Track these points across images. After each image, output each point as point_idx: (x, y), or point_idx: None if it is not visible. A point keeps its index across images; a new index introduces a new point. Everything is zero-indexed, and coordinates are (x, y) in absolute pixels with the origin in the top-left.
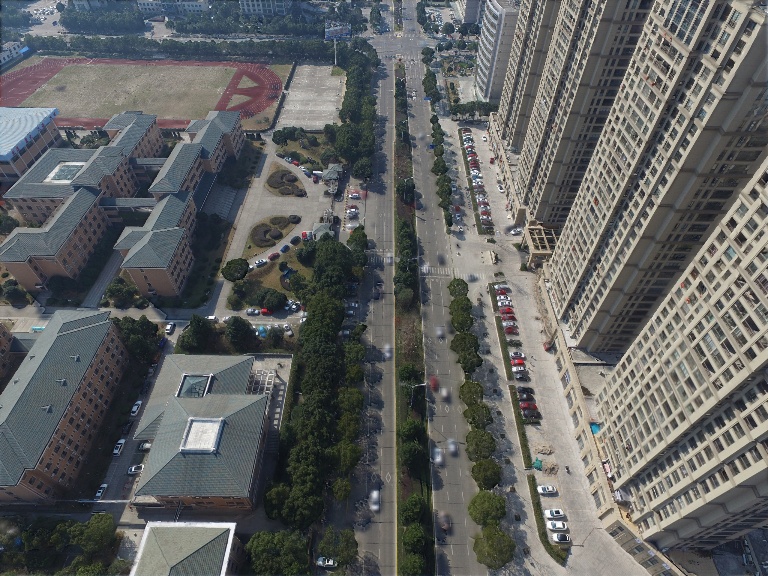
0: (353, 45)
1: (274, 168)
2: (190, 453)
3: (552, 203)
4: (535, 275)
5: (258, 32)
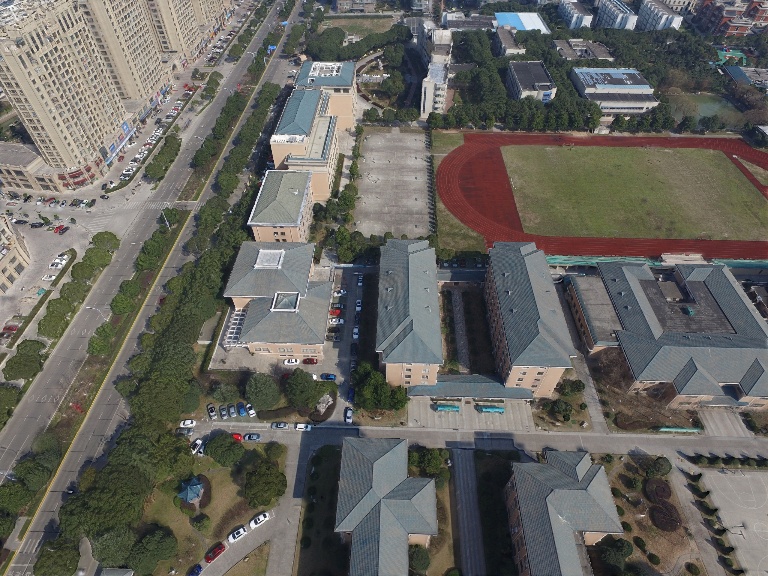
0: None
1: None
2: None
3: None
4: None
5: None
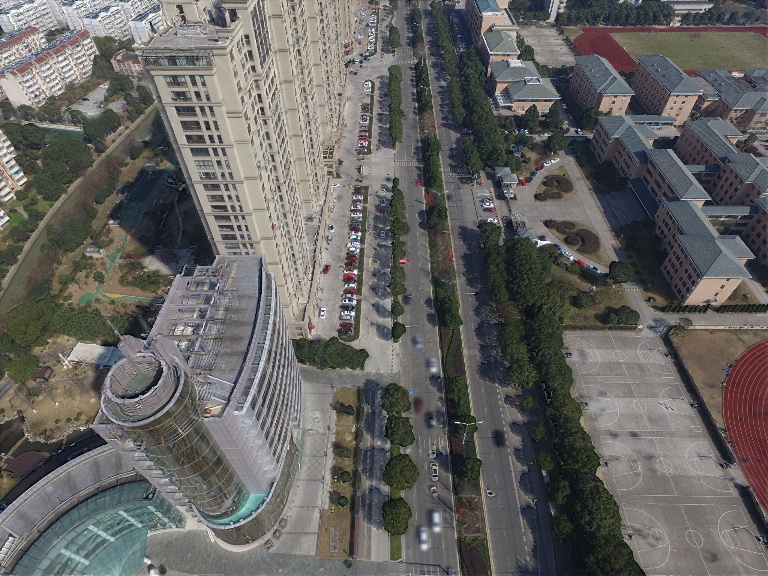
0: None
1: (603, 257)
2: None
3: None
4: None
5: None
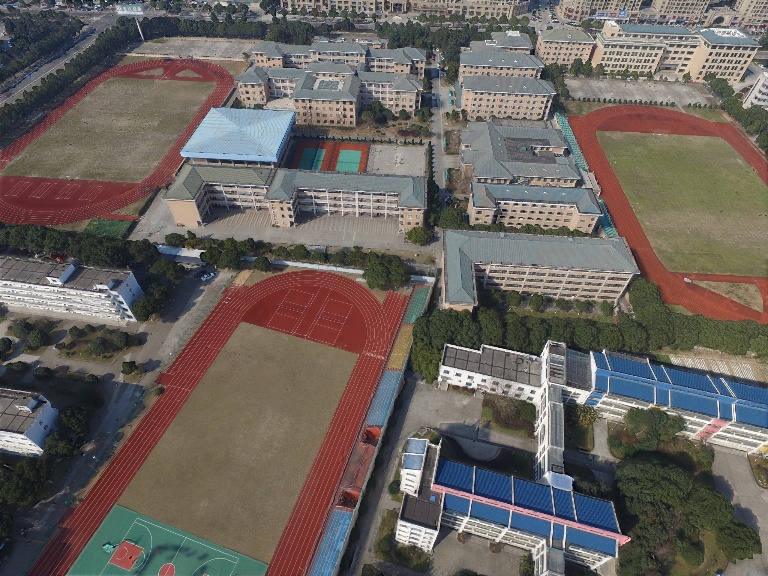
0: None
1: None
2: None
3: None
4: (409, 12)
5: None
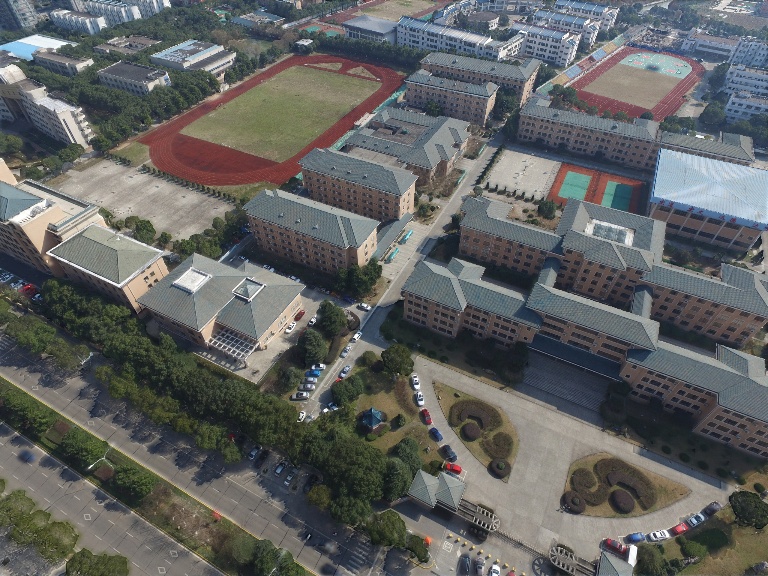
0: None
1: (664, 484)
2: None
3: None
4: None
5: None
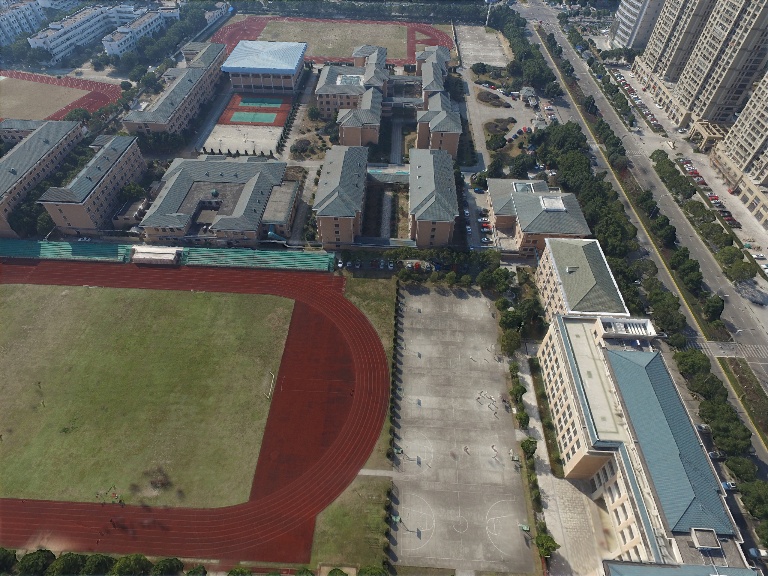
0: (498, 11)
1: (478, 90)
2: (551, 211)
3: (719, 104)
4: (706, 155)
5: (409, 1)
